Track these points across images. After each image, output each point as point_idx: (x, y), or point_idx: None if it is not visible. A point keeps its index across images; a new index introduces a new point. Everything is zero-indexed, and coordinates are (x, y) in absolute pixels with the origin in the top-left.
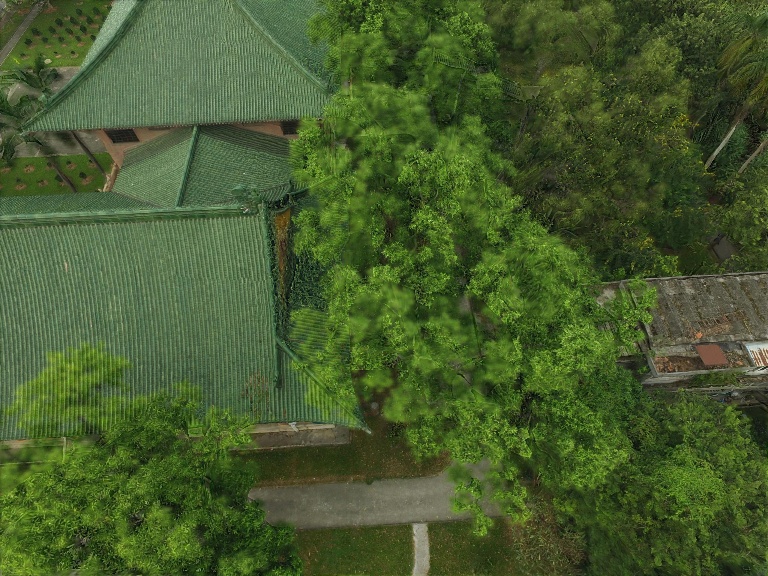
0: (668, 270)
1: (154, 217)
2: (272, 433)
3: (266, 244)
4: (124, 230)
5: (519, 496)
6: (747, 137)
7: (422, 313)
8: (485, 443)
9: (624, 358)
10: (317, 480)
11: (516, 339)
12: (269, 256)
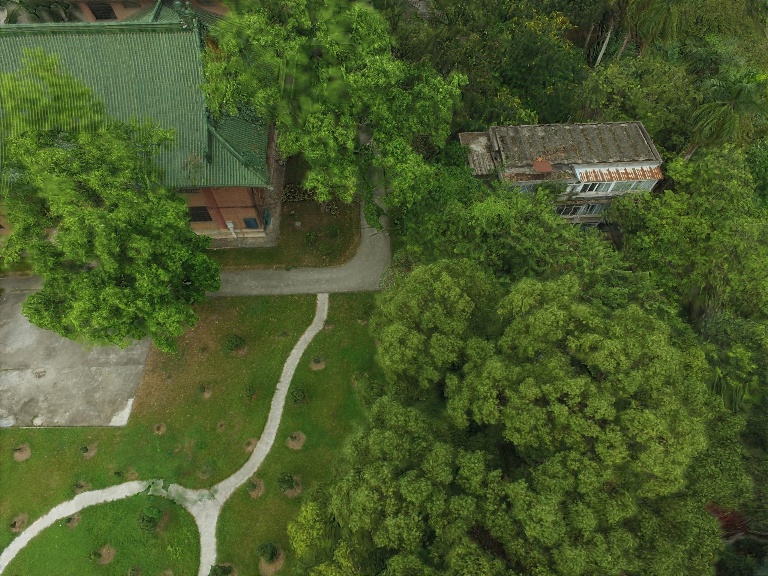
0: (527, 120)
1: (119, 29)
2: (216, 239)
3: (200, 52)
4: (98, 40)
5: (350, 181)
6: (631, 49)
7: None
8: (325, 139)
9: (484, 177)
10: (248, 267)
11: (343, 68)
12: (202, 61)
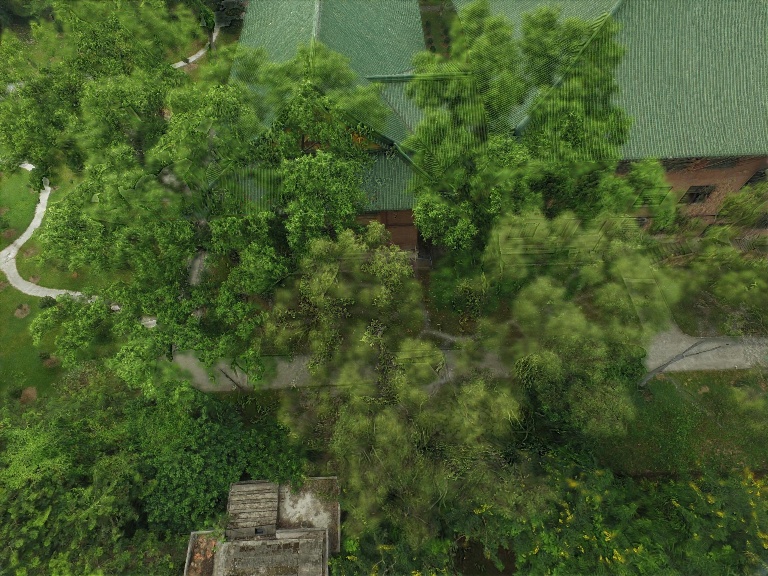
0: None
1: None
2: None
3: None
4: None
5: (39, 256)
6: None
7: (355, 333)
8: None
9: None
10: None
11: None
12: (283, 112)
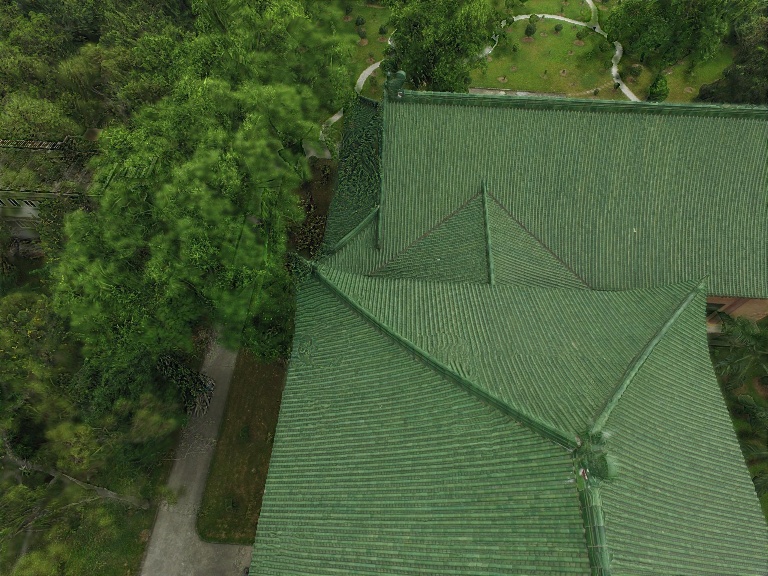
0: None
1: None
2: None
3: None
4: None
5: (269, 10)
6: None
7: None
8: None
9: None
10: None
11: None
12: None
